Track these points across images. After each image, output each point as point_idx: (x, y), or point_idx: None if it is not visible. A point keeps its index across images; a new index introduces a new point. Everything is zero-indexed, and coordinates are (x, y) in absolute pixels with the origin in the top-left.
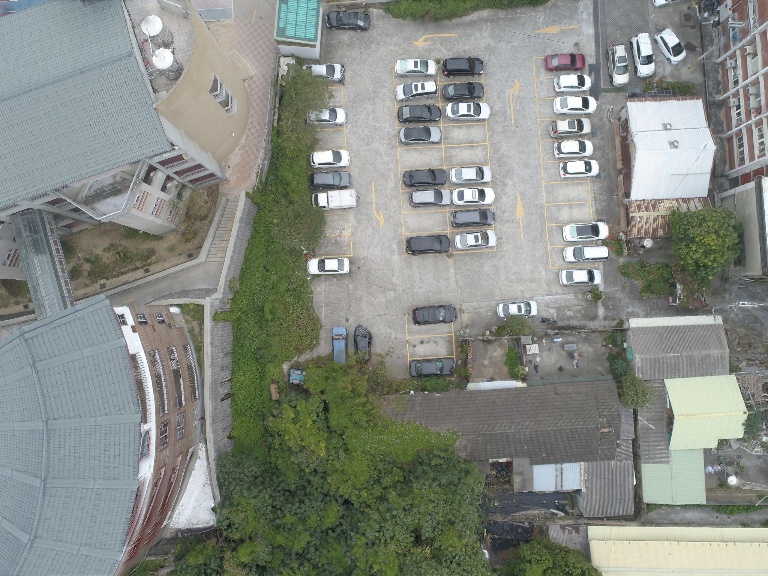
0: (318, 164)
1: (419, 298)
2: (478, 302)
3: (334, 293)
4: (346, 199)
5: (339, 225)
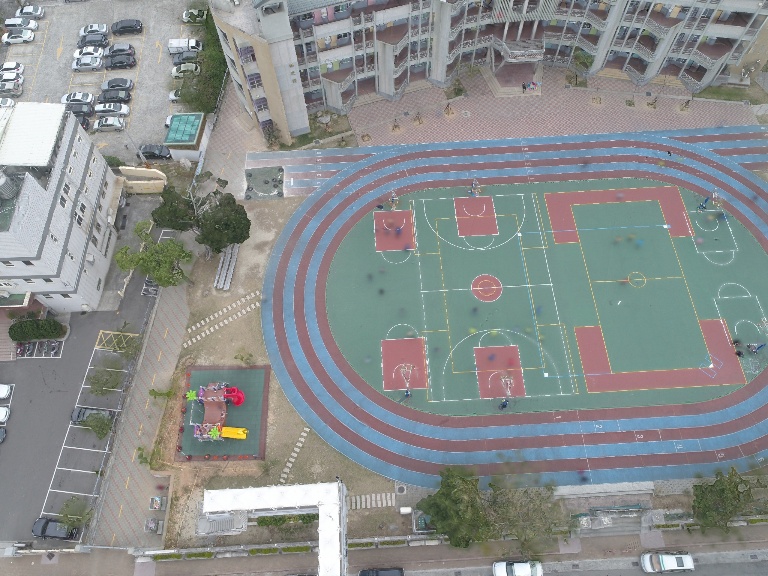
0: None
1: (140, 3)
2: (101, 2)
3: (197, 5)
4: (175, 42)
5: None
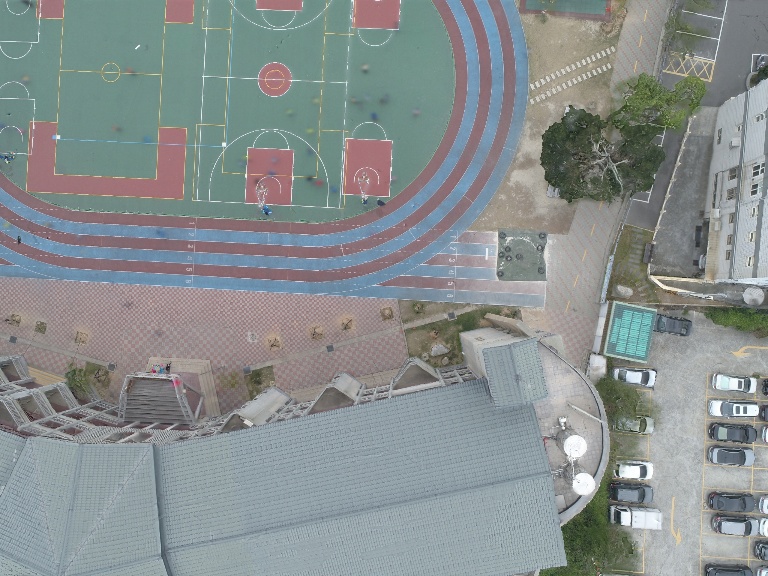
0: (622, 477)
1: None
2: None
3: None
4: (652, 522)
5: (632, 538)
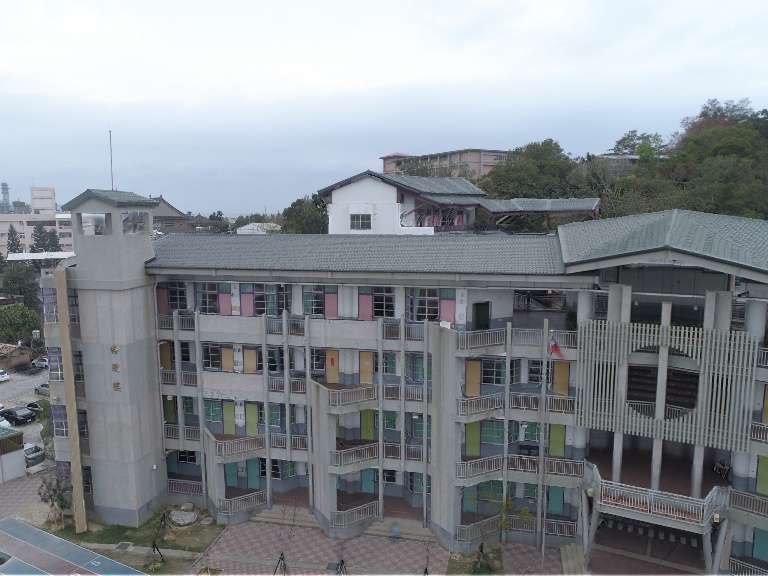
0: None
1: None
2: None
3: None
4: None
5: None
